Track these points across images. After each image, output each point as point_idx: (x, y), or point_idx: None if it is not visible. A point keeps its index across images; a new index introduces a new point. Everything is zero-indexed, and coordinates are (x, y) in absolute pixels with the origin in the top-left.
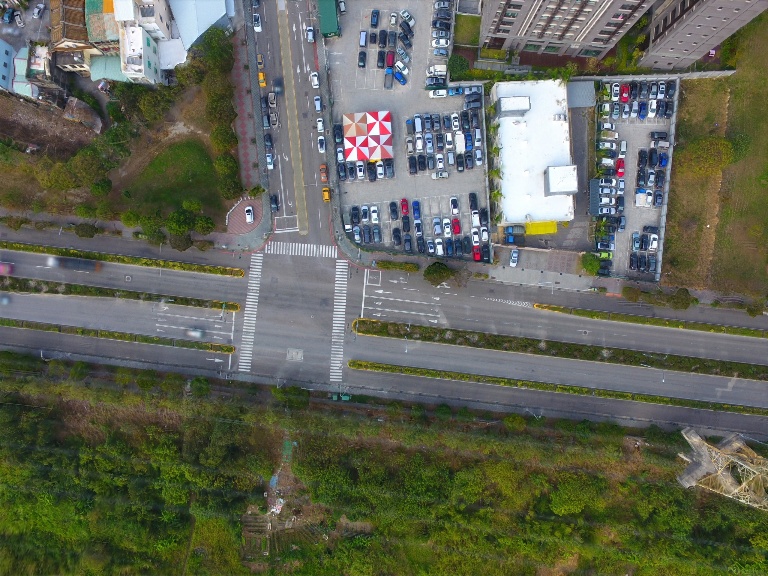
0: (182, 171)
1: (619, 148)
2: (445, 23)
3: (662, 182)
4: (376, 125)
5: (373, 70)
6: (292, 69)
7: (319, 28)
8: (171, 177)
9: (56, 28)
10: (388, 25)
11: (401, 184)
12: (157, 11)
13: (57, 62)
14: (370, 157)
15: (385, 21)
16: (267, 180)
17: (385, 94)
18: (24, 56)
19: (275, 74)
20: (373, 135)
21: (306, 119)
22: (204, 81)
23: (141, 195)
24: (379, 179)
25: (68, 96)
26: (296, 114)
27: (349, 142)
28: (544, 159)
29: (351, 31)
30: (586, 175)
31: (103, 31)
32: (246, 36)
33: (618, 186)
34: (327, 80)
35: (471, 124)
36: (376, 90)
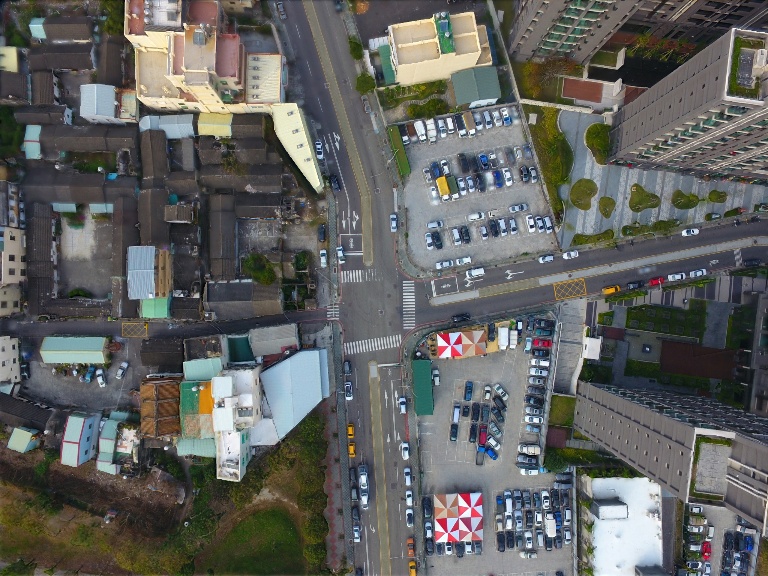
0: (266, 541)
1: (706, 532)
2: (539, 400)
3: (747, 568)
4: (468, 510)
5: (464, 442)
6: (382, 438)
7: (411, 397)
8: (254, 546)
9: (147, 418)
10: (481, 397)
11: (488, 559)
12: (255, 411)
13: (145, 445)
14: (460, 540)
15: (478, 393)
16: (353, 552)
17: (476, 467)
18: (110, 435)
19: (365, 443)
20: (464, 517)
21: (395, 490)
22: (296, 465)
23: (222, 564)
24: (466, 553)
25: (151, 464)
26: (385, 484)
27: (440, 526)
28: (636, 554)
29: (443, 402)
30: (672, 556)
31: (198, 430)
32: (337, 404)
33: (704, 570)
34: (418, 452)
35: (561, 501)
36: (467, 463)
